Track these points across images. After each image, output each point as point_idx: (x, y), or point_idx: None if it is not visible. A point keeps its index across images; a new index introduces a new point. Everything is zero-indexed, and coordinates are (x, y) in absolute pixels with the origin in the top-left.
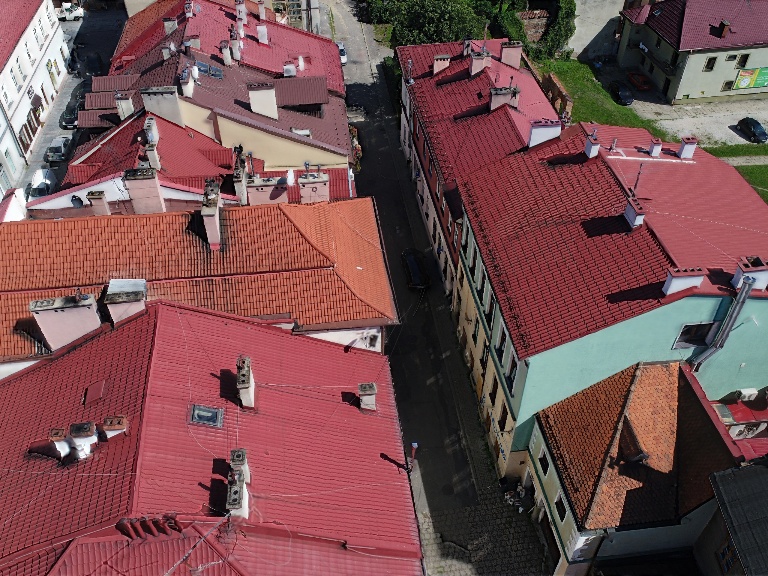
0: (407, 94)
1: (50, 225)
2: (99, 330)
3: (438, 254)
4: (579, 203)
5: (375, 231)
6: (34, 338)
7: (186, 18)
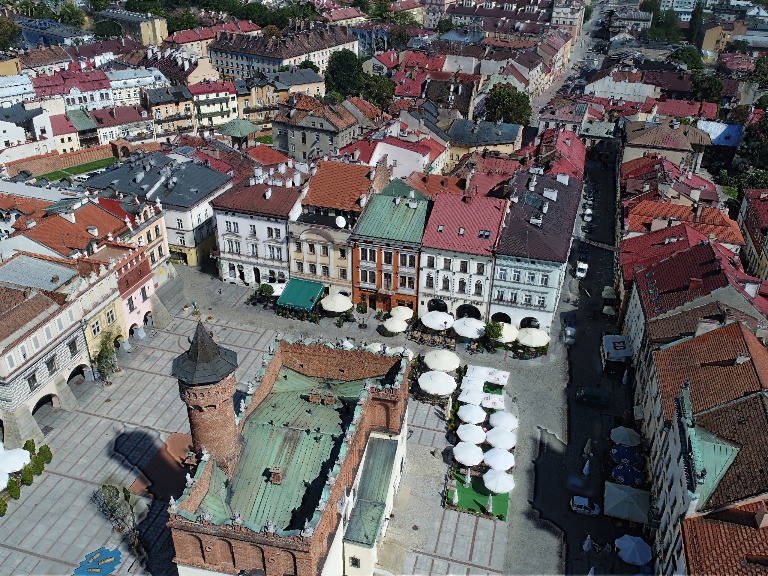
0: (745, 207)
1: (655, 203)
2: (666, 228)
3: (750, 259)
4: None
5: (739, 228)
6: (646, 228)
7: (663, 165)
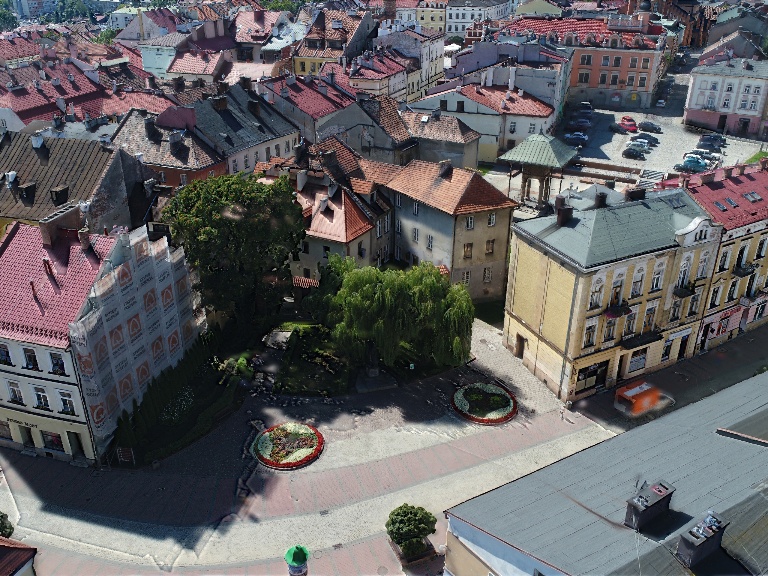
0: None
1: None
2: None
3: None
4: (8, 45)
5: None
6: None
7: None
